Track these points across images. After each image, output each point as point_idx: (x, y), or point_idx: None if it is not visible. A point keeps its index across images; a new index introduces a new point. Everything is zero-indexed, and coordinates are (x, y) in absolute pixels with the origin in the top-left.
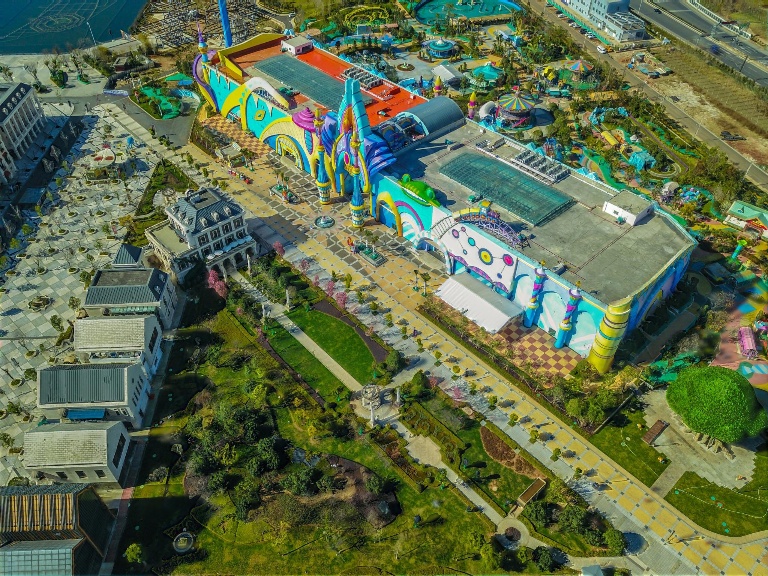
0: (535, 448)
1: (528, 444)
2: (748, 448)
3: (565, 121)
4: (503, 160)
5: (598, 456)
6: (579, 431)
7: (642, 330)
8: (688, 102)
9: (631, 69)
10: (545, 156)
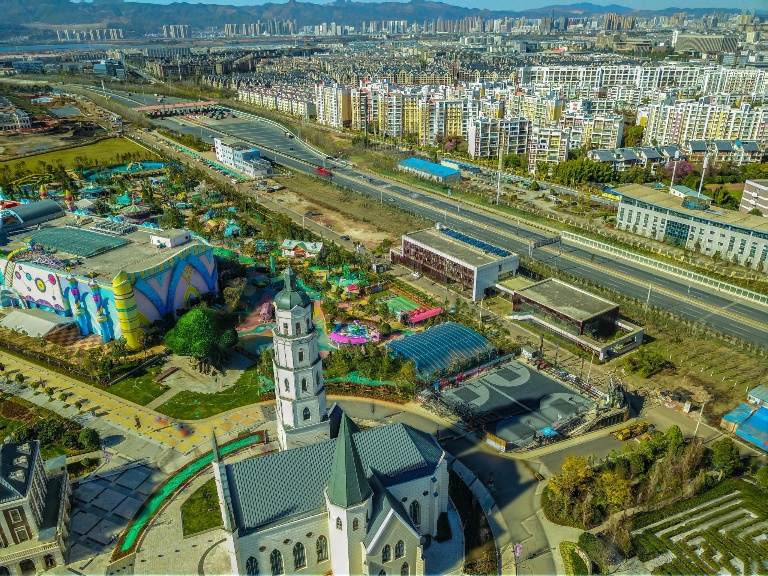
0: (51, 404)
1: (46, 403)
2: (239, 369)
3: (177, 217)
4: (84, 229)
5: (108, 397)
6: (98, 386)
7: (176, 316)
8: (289, 201)
9: (255, 190)
10: (120, 222)
